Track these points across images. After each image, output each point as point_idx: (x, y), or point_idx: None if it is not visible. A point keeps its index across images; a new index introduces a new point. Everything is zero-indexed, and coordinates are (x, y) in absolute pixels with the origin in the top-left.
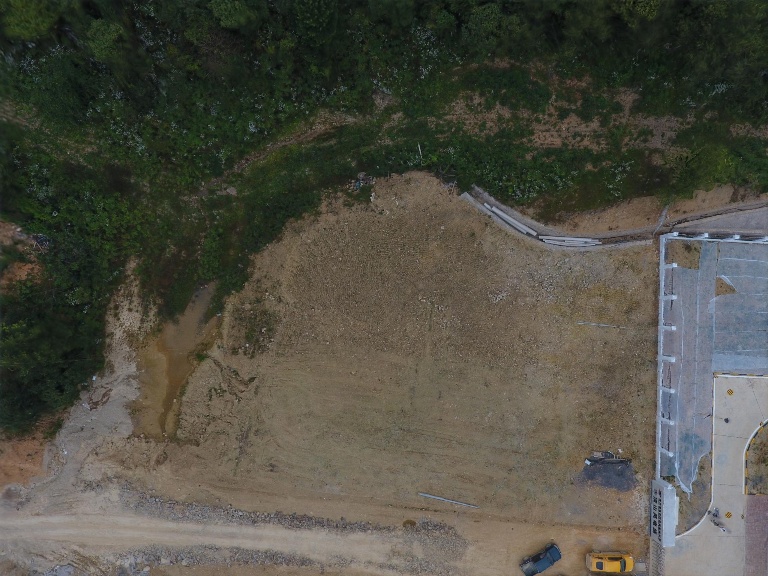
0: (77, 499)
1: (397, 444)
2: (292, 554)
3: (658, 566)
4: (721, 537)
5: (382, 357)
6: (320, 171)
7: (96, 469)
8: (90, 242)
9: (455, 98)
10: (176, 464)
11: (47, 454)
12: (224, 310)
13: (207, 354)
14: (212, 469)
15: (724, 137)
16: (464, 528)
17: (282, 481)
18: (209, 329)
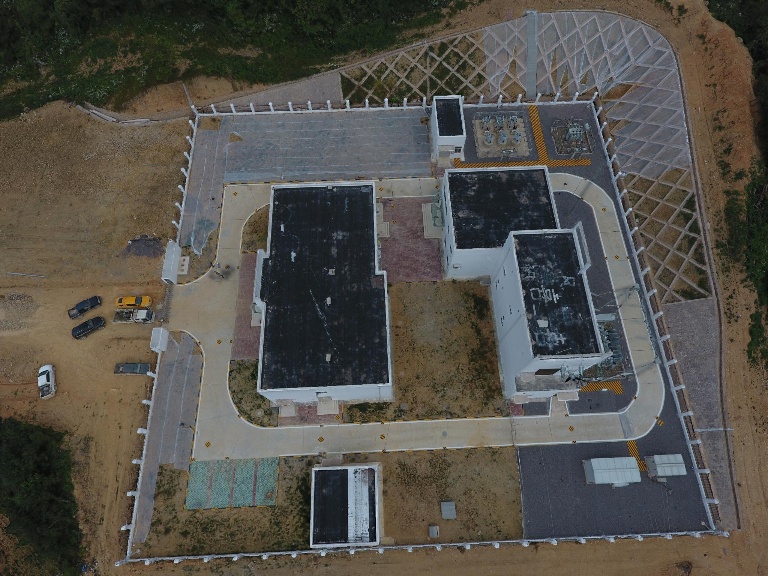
0: None
1: (2, 245)
2: None
3: (169, 302)
4: (221, 282)
5: (5, 196)
6: (1, 109)
7: None
8: None
9: (81, 62)
10: None
11: None
12: None
13: None
14: None
15: (212, 53)
16: (38, 296)
17: None
18: None
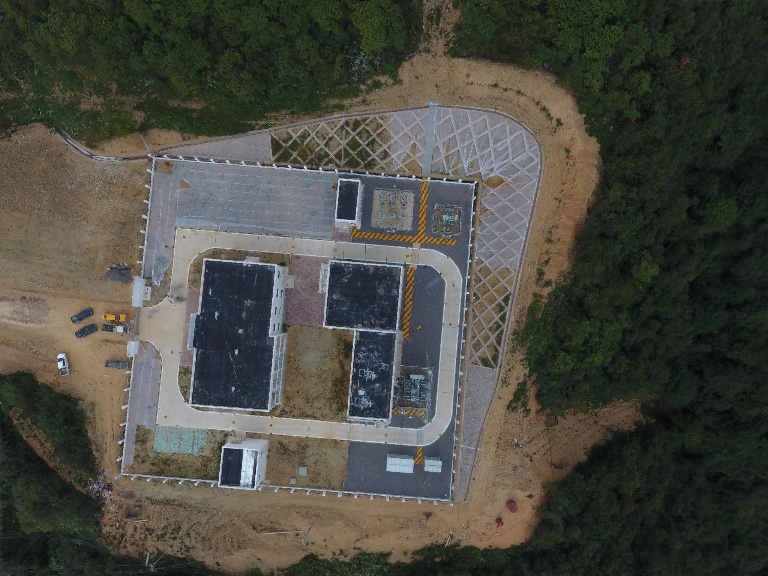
0: None
1: (17, 257)
2: None
3: (138, 320)
4: (173, 309)
5: (13, 214)
6: None
7: None
8: None
9: (54, 85)
10: None
11: None
12: None
13: None
14: None
15: (163, 106)
16: (49, 301)
17: None
18: None
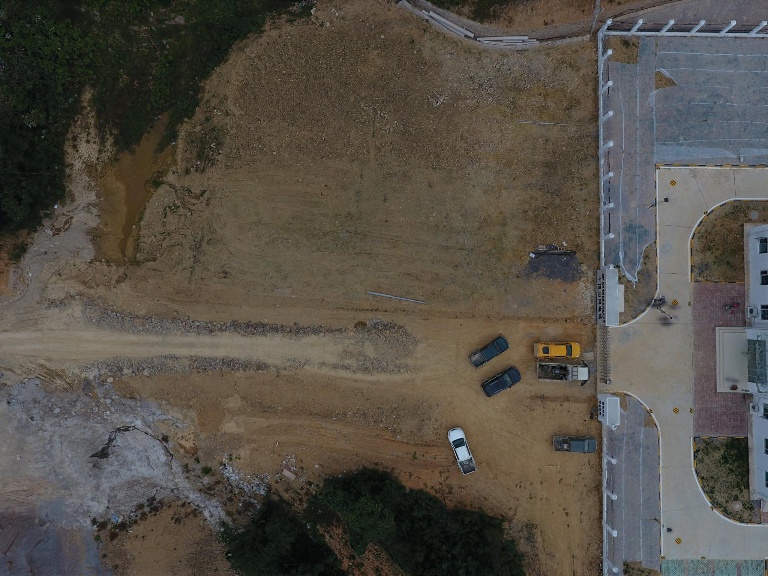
0: (42, 316)
1: (345, 246)
2: (248, 360)
3: (605, 353)
4: (668, 324)
5: (327, 164)
6: None
7: (59, 288)
8: (43, 66)
9: None
10: (135, 280)
11: (12, 274)
12: (178, 138)
13: (163, 180)
14: (168, 279)
15: None
16: (414, 326)
17: (235, 287)
18: (164, 158)
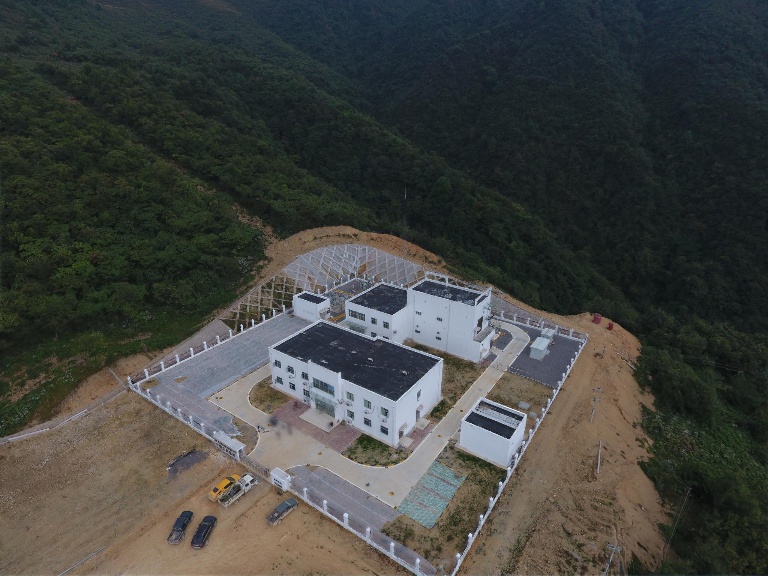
0: None
1: None
2: None
3: None
4: (276, 433)
5: None
6: None
7: None
8: None
9: None
10: None
11: None
12: None
13: None
14: None
15: (117, 345)
16: (109, 570)
17: None
18: None
